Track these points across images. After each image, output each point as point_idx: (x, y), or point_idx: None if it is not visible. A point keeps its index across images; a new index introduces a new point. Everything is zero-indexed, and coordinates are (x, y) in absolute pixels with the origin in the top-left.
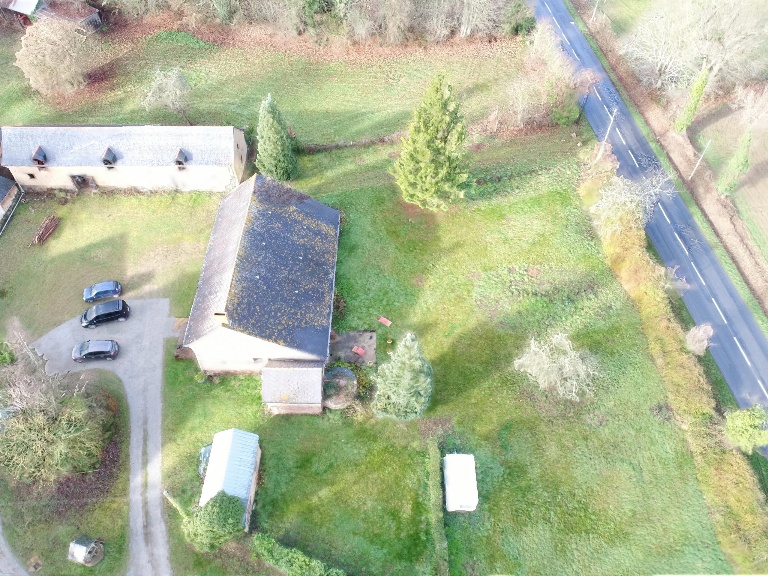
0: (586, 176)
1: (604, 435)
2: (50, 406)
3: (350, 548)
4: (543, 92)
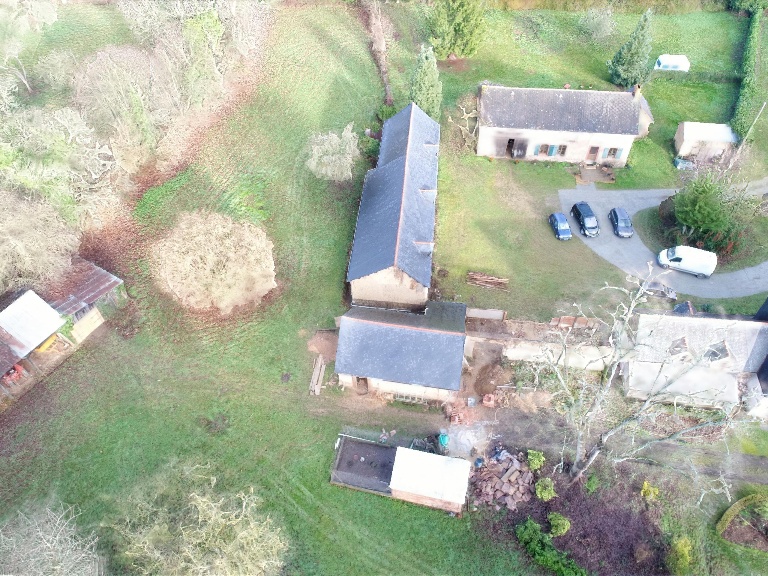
0: (432, 4)
1: (624, 31)
2: (716, 181)
3: (718, 107)
4: (334, 5)
